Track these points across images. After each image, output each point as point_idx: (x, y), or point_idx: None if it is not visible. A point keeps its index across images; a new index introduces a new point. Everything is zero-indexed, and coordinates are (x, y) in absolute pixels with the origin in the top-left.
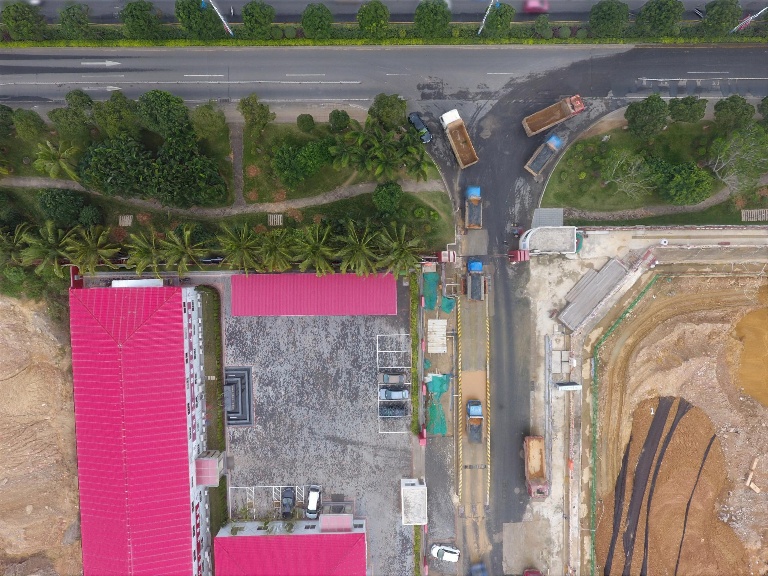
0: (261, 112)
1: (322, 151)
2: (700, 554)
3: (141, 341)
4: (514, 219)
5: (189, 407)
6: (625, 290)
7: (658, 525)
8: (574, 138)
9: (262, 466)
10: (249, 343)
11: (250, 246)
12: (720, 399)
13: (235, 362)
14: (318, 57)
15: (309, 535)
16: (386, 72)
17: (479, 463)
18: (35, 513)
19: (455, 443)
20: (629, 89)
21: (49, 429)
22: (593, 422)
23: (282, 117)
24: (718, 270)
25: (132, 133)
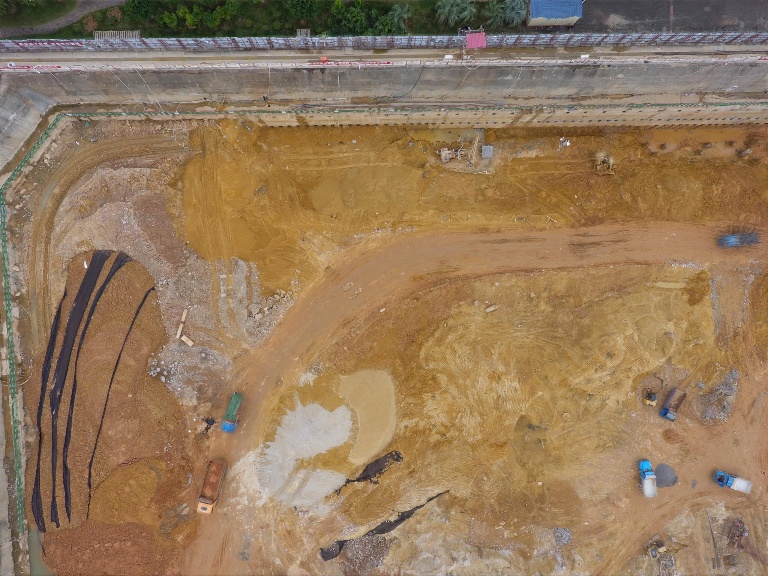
0: None
1: None
2: (123, 409)
3: None
4: None
5: None
6: None
7: (84, 381)
8: None
9: None
10: None
11: None
12: (145, 248)
13: None
14: None
15: None
16: None
17: None
18: None
19: None
20: None
21: None
22: (8, 273)
23: None
24: (129, 111)
25: None
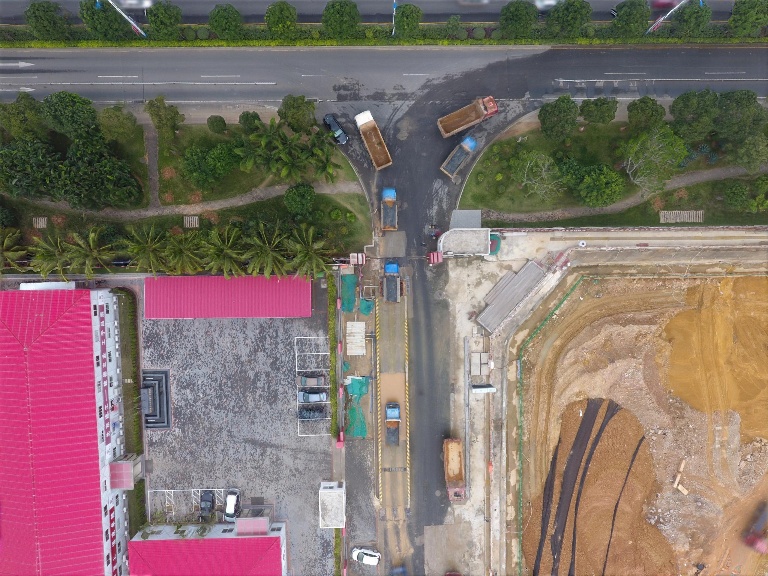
0: (167, 113)
1: (231, 153)
2: (627, 556)
3: (48, 344)
4: (432, 221)
5: (101, 410)
6: (544, 292)
7: (586, 527)
8: (491, 139)
9: (181, 469)
10: (166, 346)
11: (157, 248)
12: (647, 401)
13: (153, 365)
14: (233, 58)
15: (224, 539)
16: (301, 73)
17: (399, 466)
18: None
19: (375, 446)
20: (546, 90)
21: None
22: (520, 424)
23: (197, 118)
24: (644, 271)
25: (39, 135)
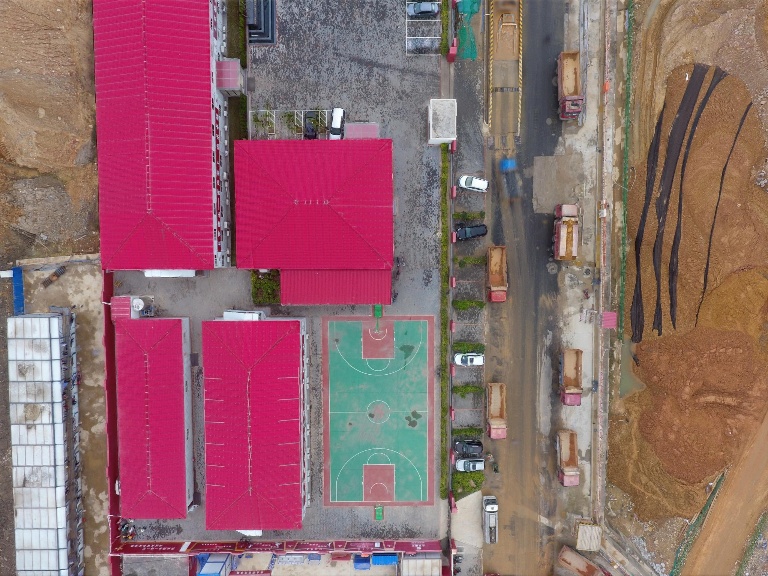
0: None
1: None
2: (736, 216)
3: None
4: None
5: None
6: None
7: (692, 190)
8: None
9: (284, 88)
10: None
11: None
12: (758, 58)
13: None
14: None
15: (333, 140)
16: None
17: (510, 86)
18: (47, 119)
19: (485, 67)
20: None
21: (63, 39)
22: (626, 78)
23: None
24: None
25: None
